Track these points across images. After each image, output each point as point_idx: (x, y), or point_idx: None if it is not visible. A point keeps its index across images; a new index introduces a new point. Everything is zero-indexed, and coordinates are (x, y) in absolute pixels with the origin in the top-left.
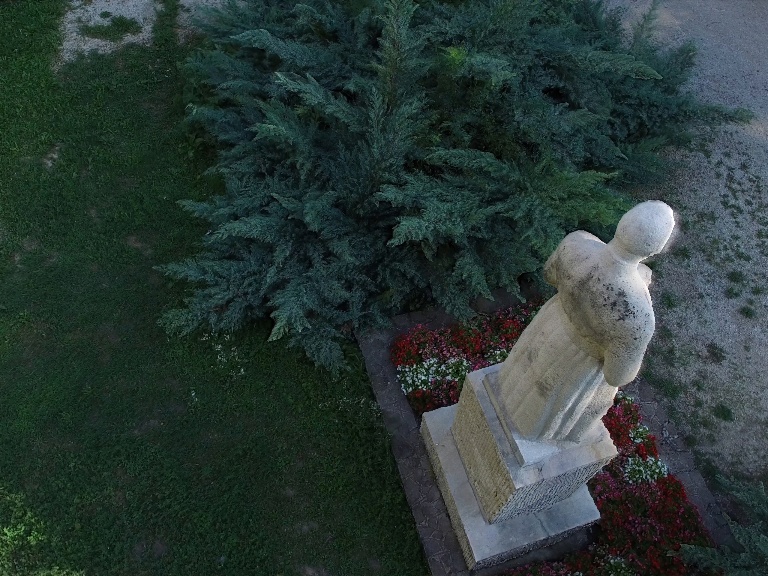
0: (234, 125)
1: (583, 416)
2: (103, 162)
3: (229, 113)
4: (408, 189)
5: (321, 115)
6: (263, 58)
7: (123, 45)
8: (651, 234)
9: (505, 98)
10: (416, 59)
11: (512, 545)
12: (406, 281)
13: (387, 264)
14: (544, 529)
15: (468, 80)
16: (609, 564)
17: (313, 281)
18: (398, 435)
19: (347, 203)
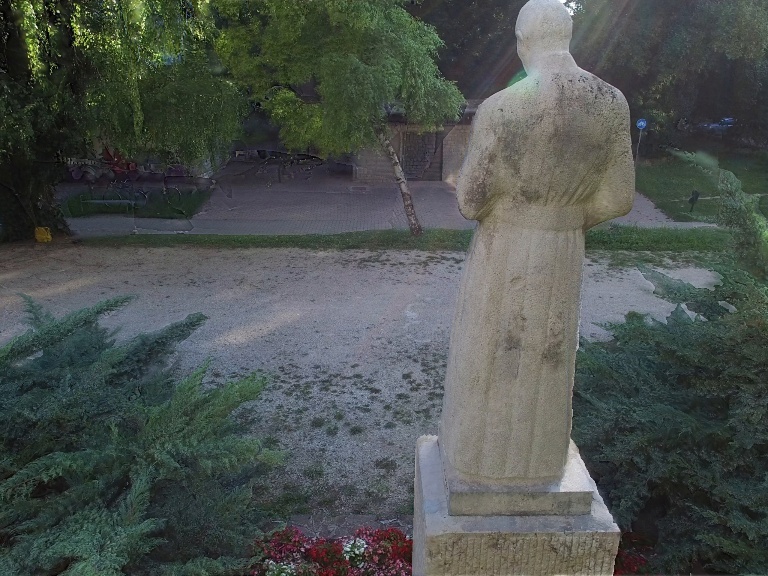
0: None
1: None
2: None
3: None
4: None
5: None
6: None
7: None
8: None
9: None
10: None
11: None
12: None
13: None
14: None
15: None
16: None
17: None
18: None
19: None
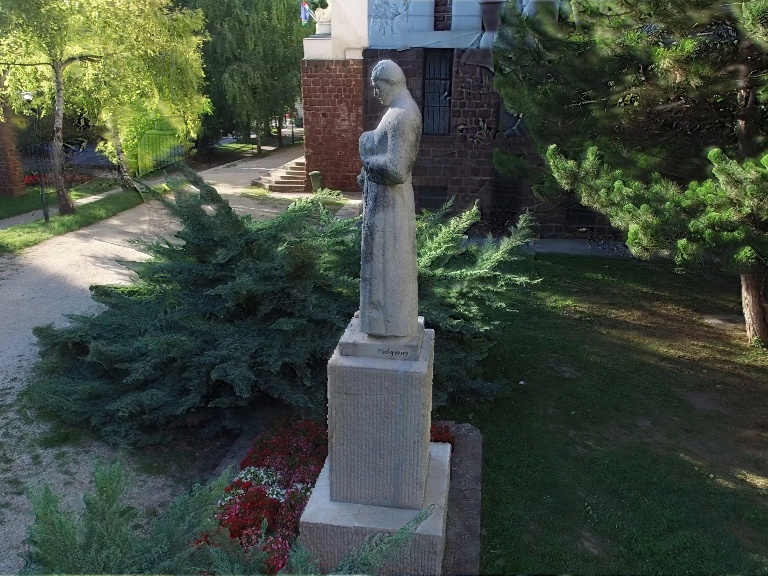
0: None
1: None
2: None
3: None
4: None
5: None
6: None
7: None
8: None
9: None
10: None
11: None
12: None
13: None
14: None
15: None
16: None
17: None
18: None
19: None
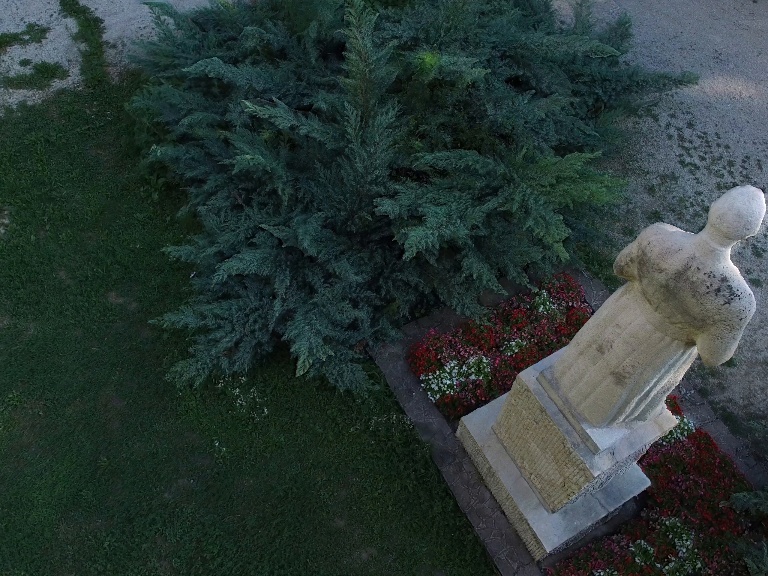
0: (199, 160)
1: (655, 396)
2: (60, 219)
3: (191, 148)
4: (401, 199)
5: (290, 137)
6: (211, 86)
7: (53, 92)
8: (750, 219)
9: (472, 93)
10: (385, 68)
11: (577, 529)
12: (410, 289)
13: (388, 276)
14: (603, 507)
15: (434, 81)
16: (665, 526)
17: (319, 306)
18: (435, 444)
19: (336, 222)
